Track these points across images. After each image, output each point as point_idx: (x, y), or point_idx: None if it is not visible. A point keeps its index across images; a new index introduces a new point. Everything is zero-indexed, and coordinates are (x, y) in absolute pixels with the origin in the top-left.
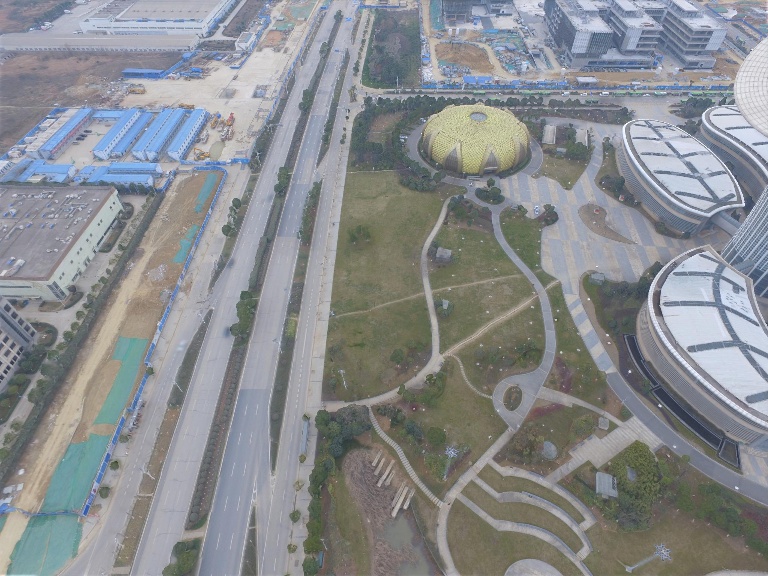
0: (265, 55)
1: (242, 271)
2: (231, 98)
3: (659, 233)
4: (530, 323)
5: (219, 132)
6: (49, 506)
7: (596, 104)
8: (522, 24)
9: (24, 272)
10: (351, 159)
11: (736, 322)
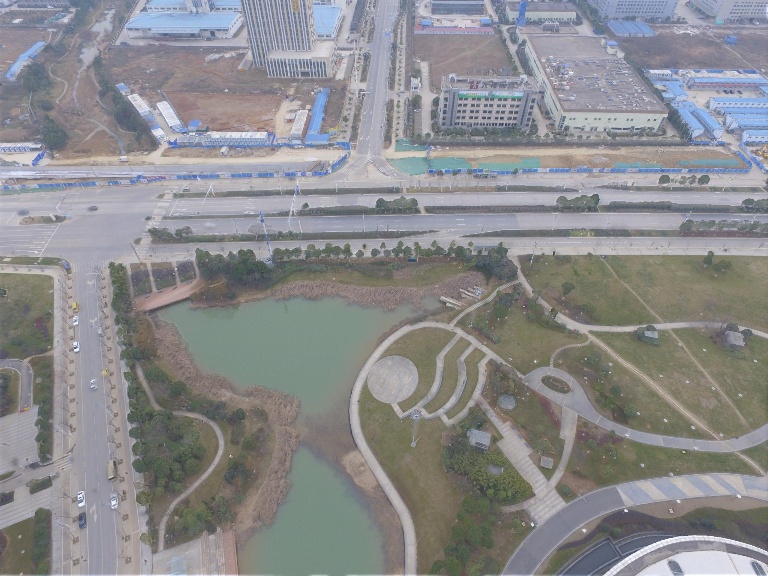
0: None
1: (625, 200)
2: None
3: None
4: (664, 419)
5: None
6: (432, 161)
7: None
8: None
9: (566, 103)
10: None
11: None
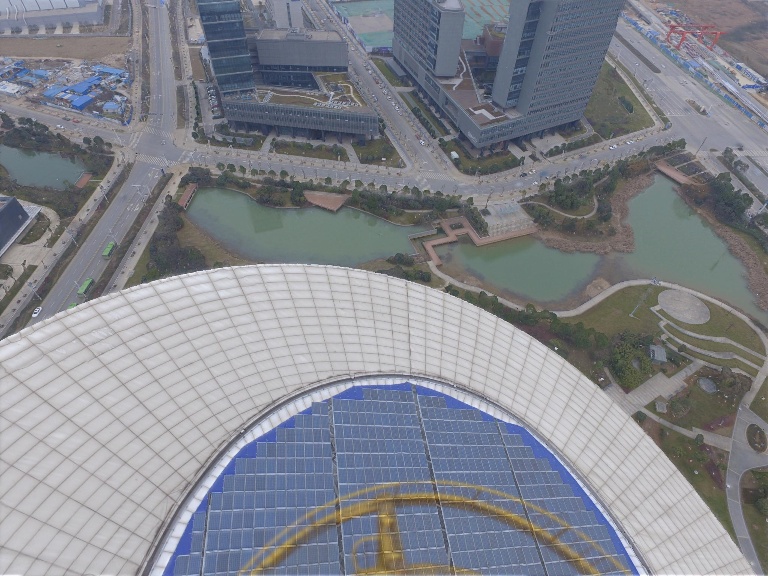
0: None
1: None
2: None
3: None
4: None
5: None
6: None
7: None
8: None
9: None
10: None
11: None
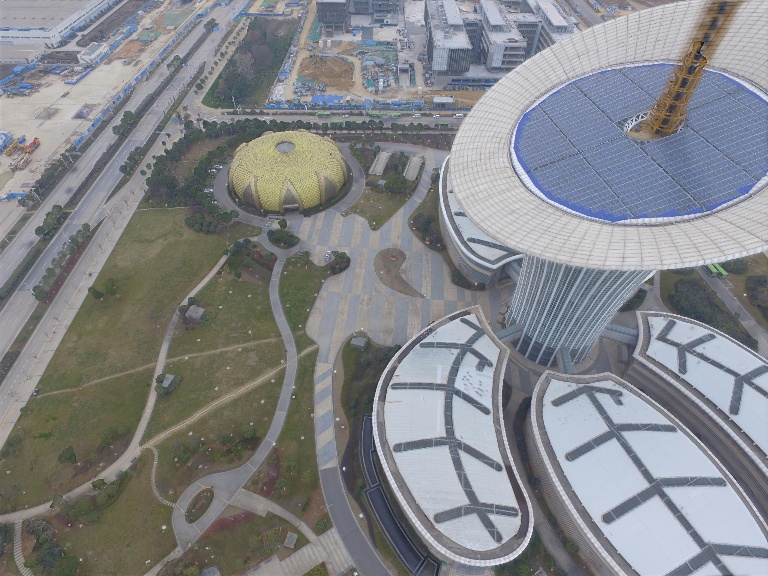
0: (112, 69)
1: None
2: (48, 119)
3: (454, 283)
4: (261, 402)
5: (14, 160)
6: None
7: (446, 127)
8: (403, 36)
9: None
10: (149, 193)
11: (460, 411)
